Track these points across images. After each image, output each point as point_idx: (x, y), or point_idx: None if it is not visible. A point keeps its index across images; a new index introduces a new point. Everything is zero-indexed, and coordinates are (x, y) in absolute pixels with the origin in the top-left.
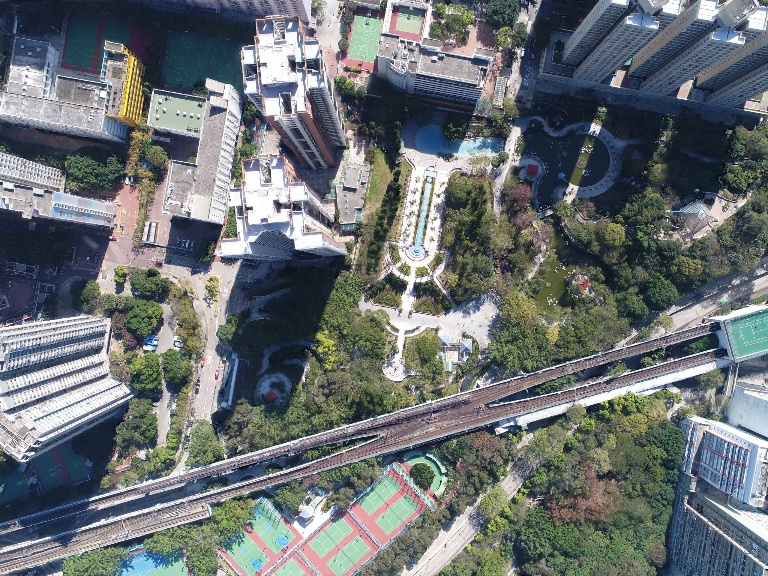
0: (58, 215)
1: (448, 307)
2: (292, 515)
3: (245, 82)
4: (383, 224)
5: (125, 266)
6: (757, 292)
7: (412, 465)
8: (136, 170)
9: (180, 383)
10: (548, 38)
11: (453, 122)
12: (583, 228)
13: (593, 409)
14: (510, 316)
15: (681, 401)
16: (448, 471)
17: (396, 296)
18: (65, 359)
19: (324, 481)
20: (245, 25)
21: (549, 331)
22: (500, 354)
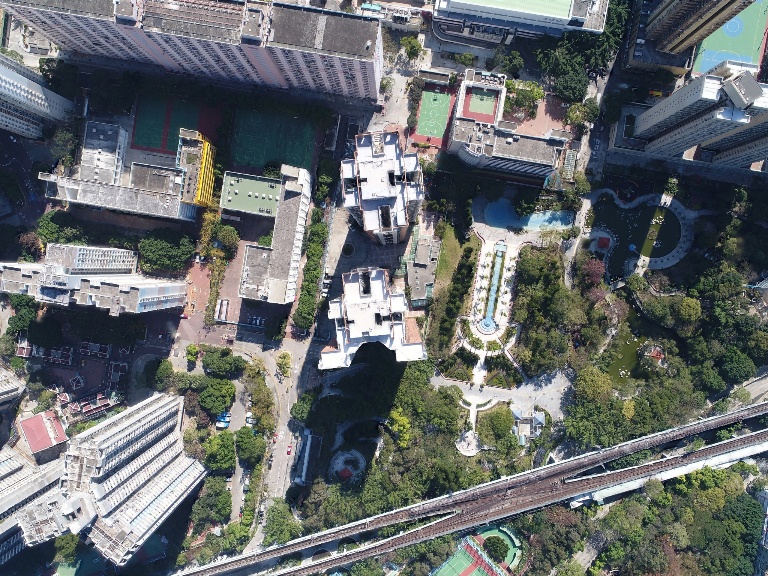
0: (142, 309)
1: (520, 381)
2: None
3: (345, 196)
4: (456, 301)
5: (197, 343)
6: None
7: (485, 538)
8: (208, 250)
9: None
10: (619, 113)
11: (525, 199)
12: (657, 302)
13: (669, 482)
14: (585, 392)
15: (758, 474)
16: (522, 545)
17: (467, 370)
18: (146, 445)
19: (400, 557)
20: (314, 104)
21: (625, 406)
22: (575, 430)
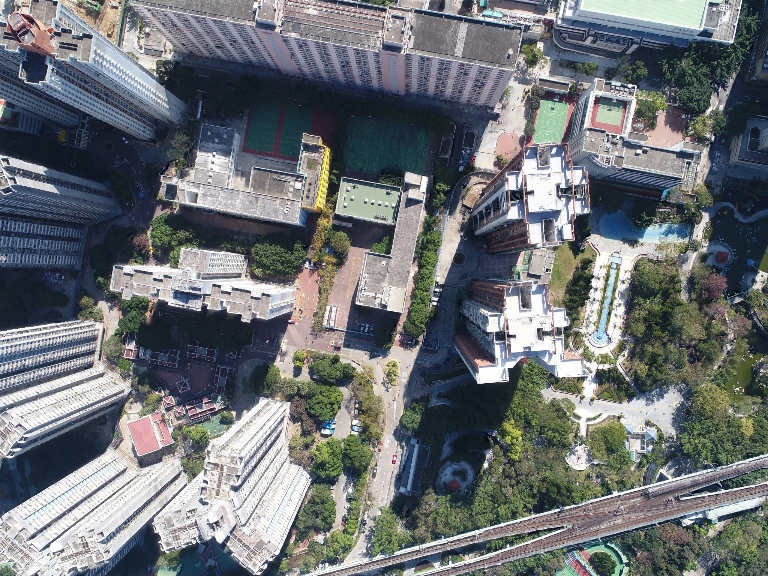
0: (270, 316)
1: (633, 395)
2: None
3: (509, 209)
4: (572, 314)
5: (303, 349)
6: None
7: (591, 553)
8: (320, 256)
9: None
10: (745, 125)
11: (646, 211)
12: None
13: None
14: (703, 409)
15: None
16: (631, 561)
17: (578, 383)
18: None
19: (507, 571)
20: (431, 111)
21: (743, 424)
22: (692, 447)
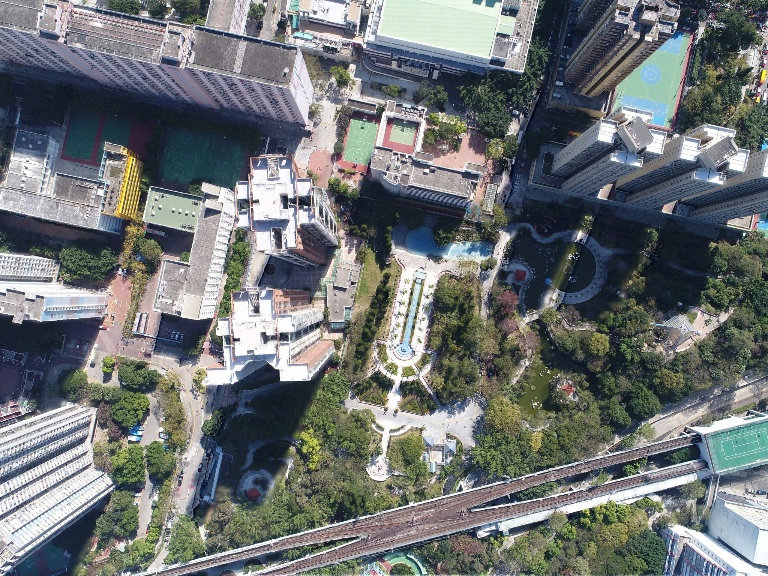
0: (49, 318)
1: (433, 408)
2: None
3: (238, 216)
4: (371, 326)
5: (114, 355)
6: (738, 403)
7: (393, 565)
8: (129, 263)
9: (163, 476)
10: (538, 150)
11: (443, 228)
12: (568, 336)
13: (575, 515)
14: (494, 422)
15: (662, 511)
16: (429, 573)
17: (382, 394)
18: (48, 456)
19: None
20: (243, 126)
21: (532, 438)
22: (483, 459)
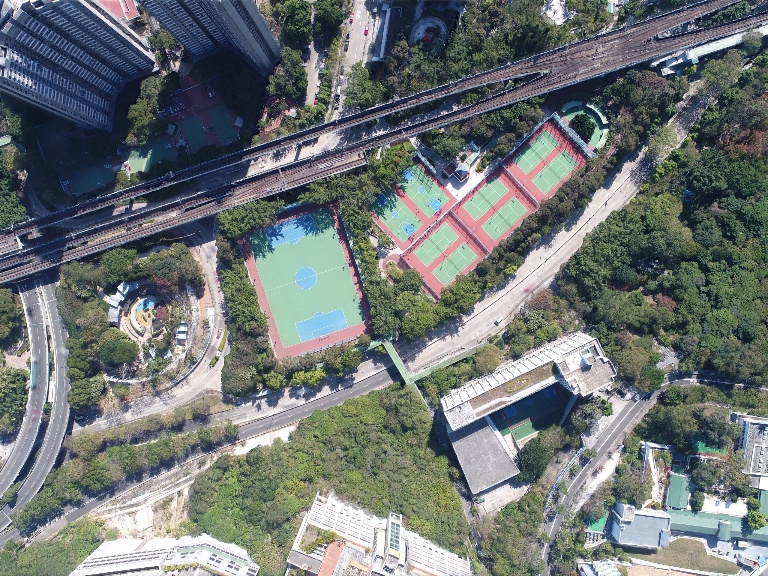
0: None
1: None
2: (447, 173)
3: None
4: None
5: None
6: None
7: (570, 119)
8: None
9: (331, 34)
10: None
11: None
12: None
13: (766, 45)
14: None
15: None
16: (610, 120)
17: None
18: None
19: (484, 126)
20: None
21: None
22: None
